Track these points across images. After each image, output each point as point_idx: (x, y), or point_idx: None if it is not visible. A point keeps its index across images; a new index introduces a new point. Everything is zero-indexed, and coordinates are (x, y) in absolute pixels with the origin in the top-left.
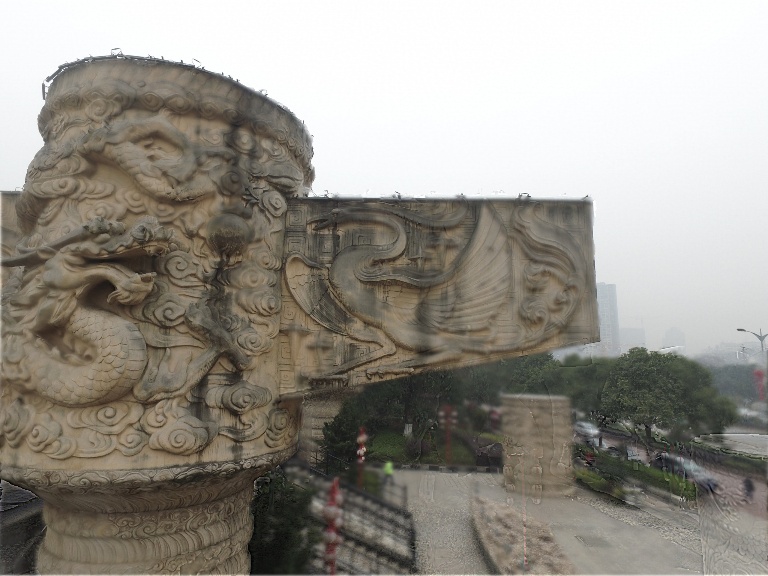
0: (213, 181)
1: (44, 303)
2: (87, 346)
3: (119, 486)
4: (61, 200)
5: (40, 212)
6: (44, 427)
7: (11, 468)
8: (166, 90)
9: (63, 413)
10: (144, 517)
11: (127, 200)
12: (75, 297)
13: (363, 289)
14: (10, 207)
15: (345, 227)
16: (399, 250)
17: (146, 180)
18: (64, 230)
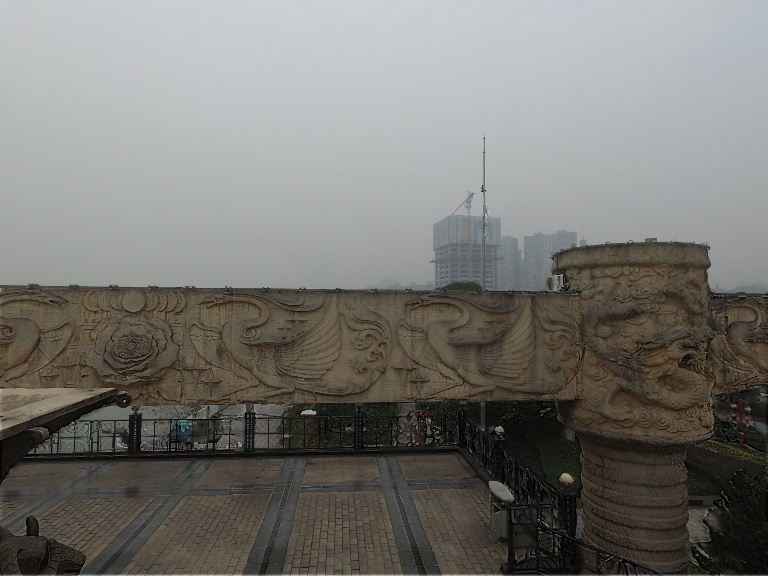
0: (707, 301)
1: (668, 366)
2: (678, 384)
3: (695, 442)
4: (649, 314)
5: (629, 317)
6: (667, 419)
7: (644, 437)
8: (693, 259)
9: (670, 413)
10: (677, 455)
11: (683, 315)
12: (678, 363)
13: (745, 345)
14: (566, 302)
15: (729, 312)
16: (758, 325)
17: (692, 306)
18: (656, 329)
